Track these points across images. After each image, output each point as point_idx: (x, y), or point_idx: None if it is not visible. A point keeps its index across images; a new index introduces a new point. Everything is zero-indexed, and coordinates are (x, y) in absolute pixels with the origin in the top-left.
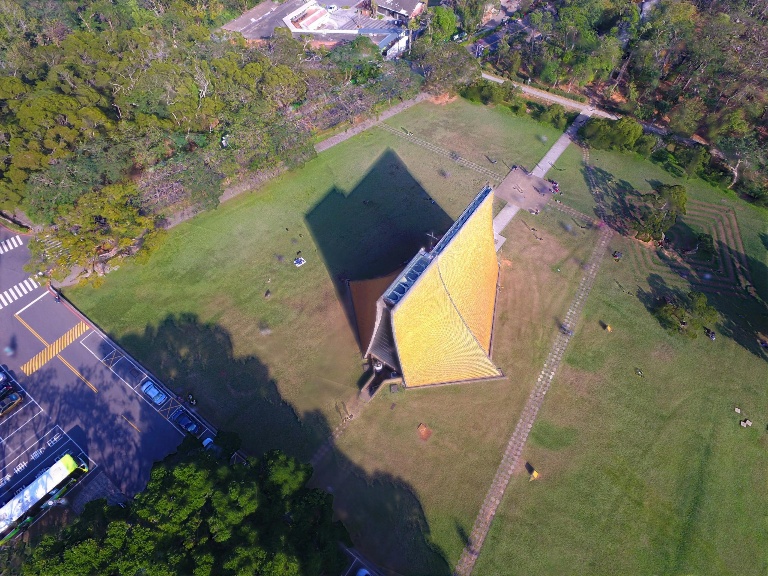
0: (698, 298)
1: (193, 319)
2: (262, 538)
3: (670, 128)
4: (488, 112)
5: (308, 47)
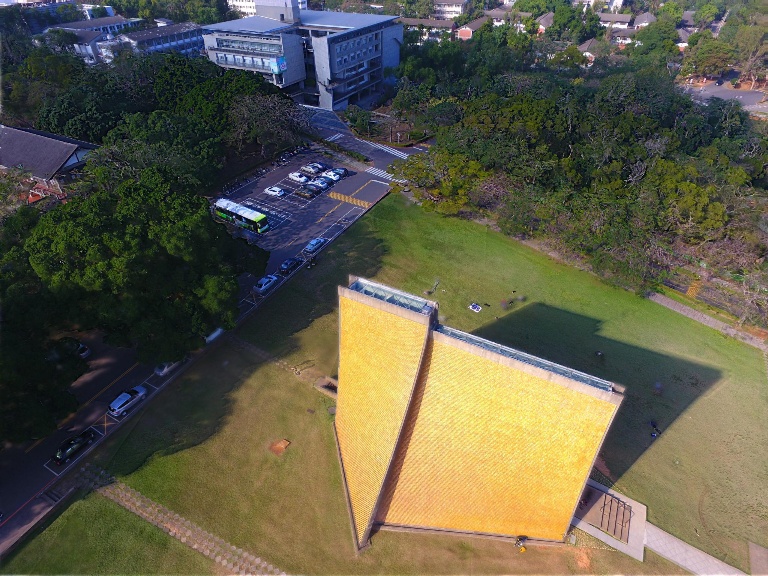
0: None
1: (387, 253)
2: (154, 269)
3: None
4: None
5: None
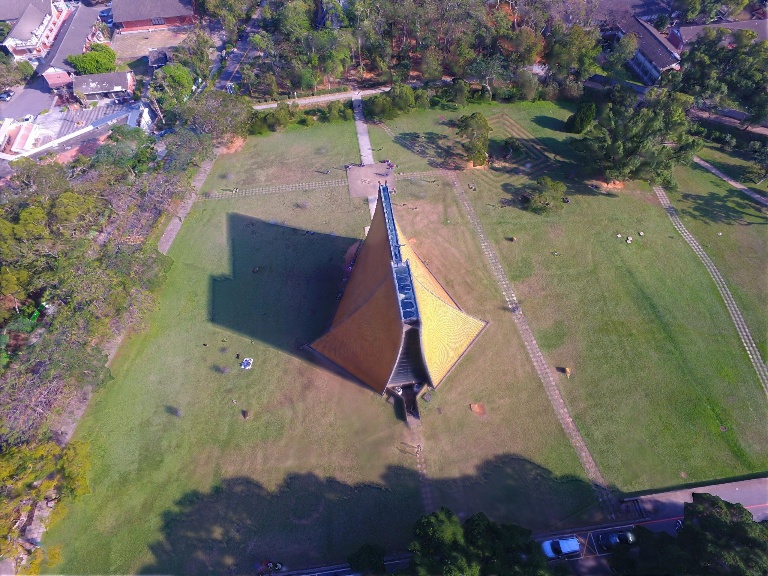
0: (545, 181)
1: (194, 498)
2: None
3: None
4: (283, 136)
5: None
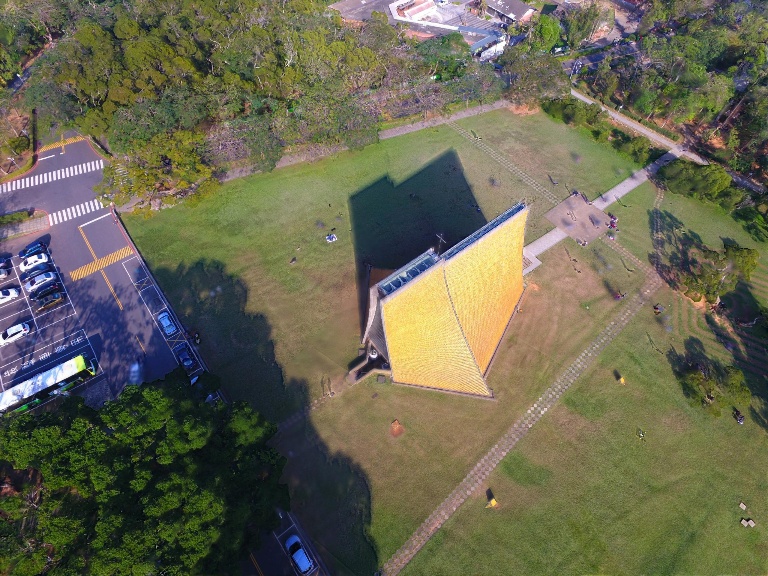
0: (734, 375)
1: (221, 267)
2: (202, 474)
3: (766, 186)
4: (567, 132)
5: (402, 36)
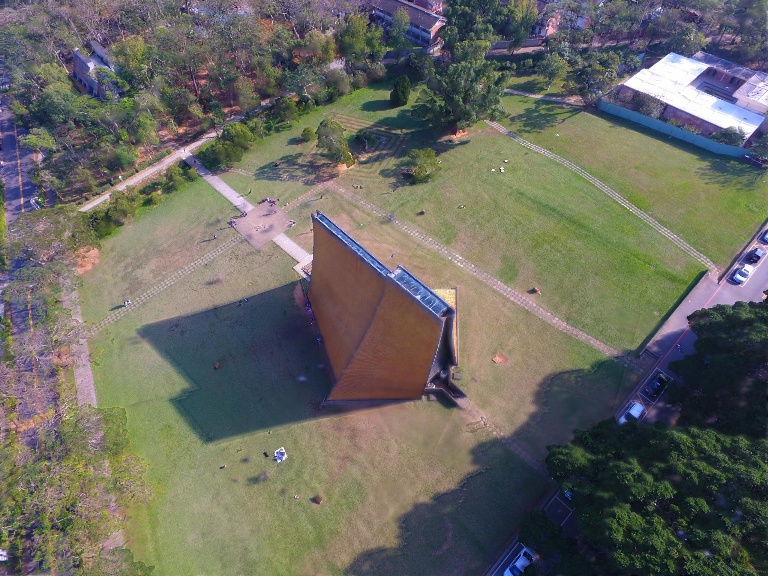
0: (416, 153)
1: None
2: (649, 466)
3: None
4: (137, 225)
5: None
